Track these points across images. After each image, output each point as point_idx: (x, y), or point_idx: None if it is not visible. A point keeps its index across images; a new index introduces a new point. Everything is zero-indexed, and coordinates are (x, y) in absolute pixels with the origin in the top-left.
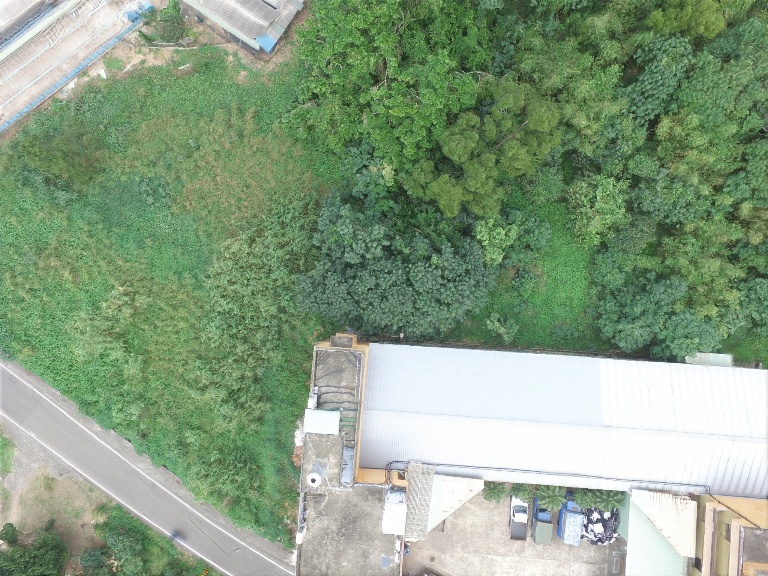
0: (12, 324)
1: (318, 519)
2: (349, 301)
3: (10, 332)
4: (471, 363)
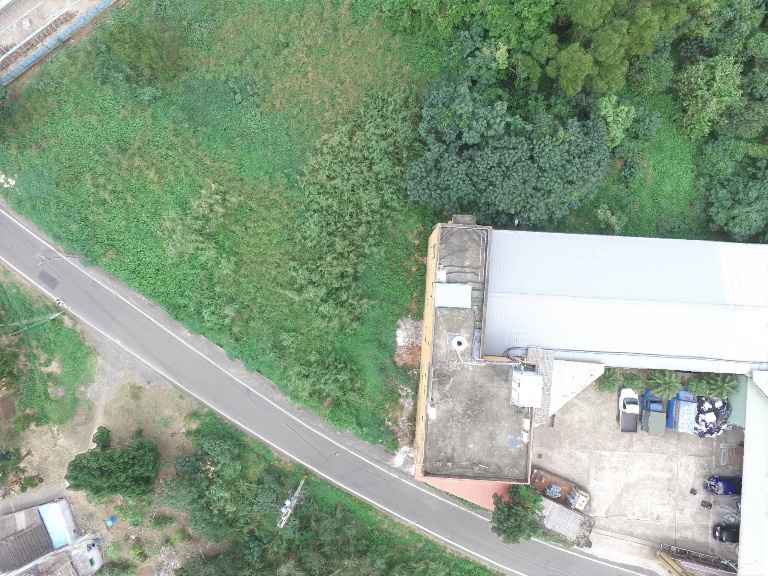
0: (94, 227)
1: (443, 401)
2: (467, 183)
3: (92, 235)
4: (589, 247)
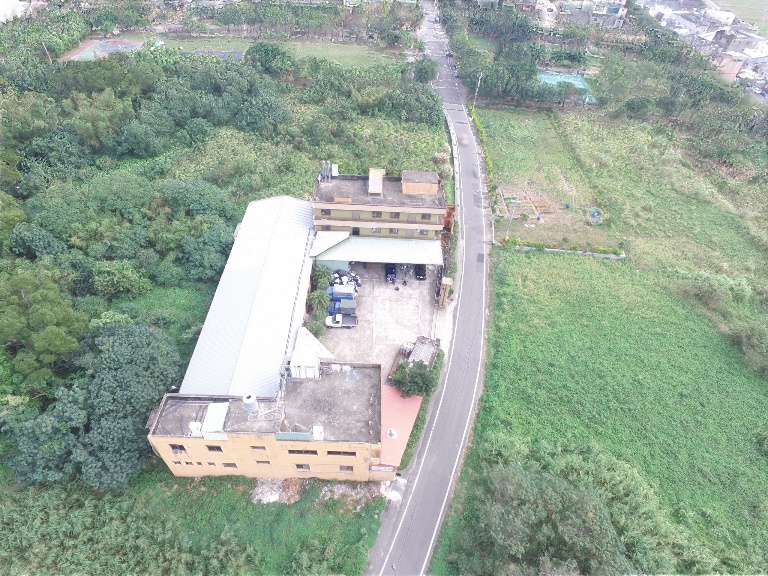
0: None
1: None
2: None
3: None
4: (208, 337)
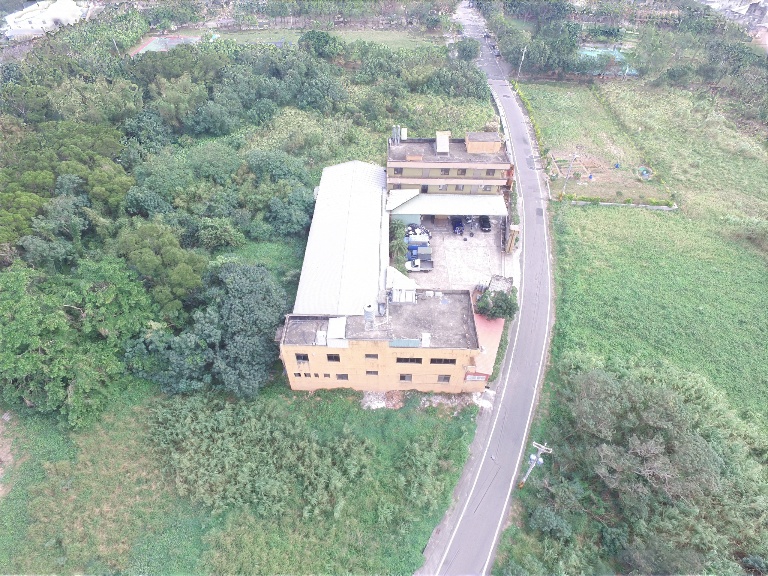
0: None
1: None
2: None
3: None
4: (309, 276)
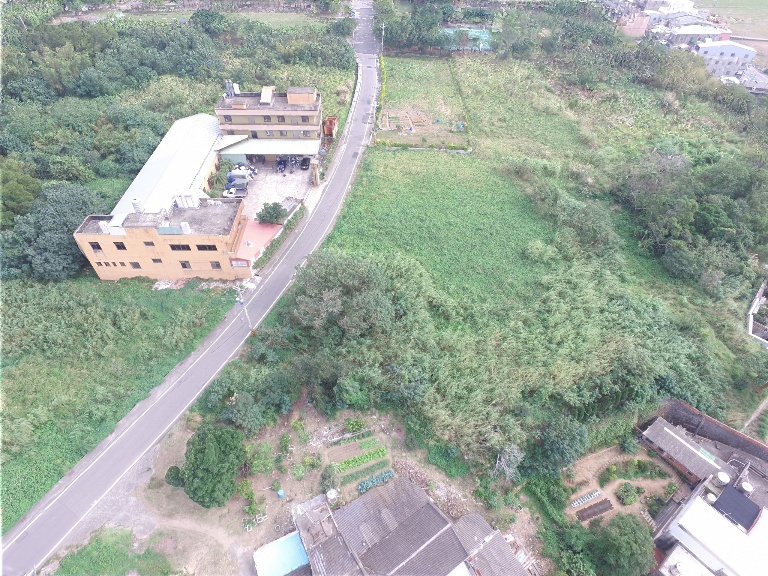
0: None
1: None
2: None
3: None
4: None
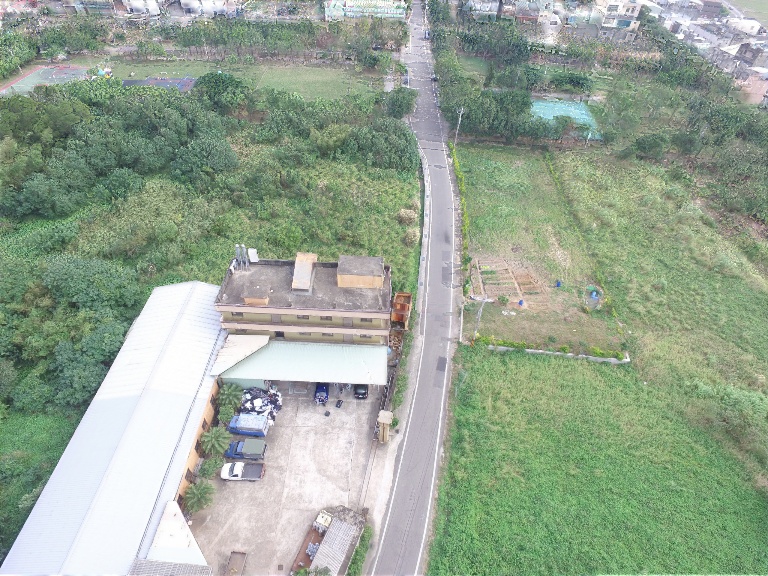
0: None
1: None
2: None
3: None
4: (38, 520)
